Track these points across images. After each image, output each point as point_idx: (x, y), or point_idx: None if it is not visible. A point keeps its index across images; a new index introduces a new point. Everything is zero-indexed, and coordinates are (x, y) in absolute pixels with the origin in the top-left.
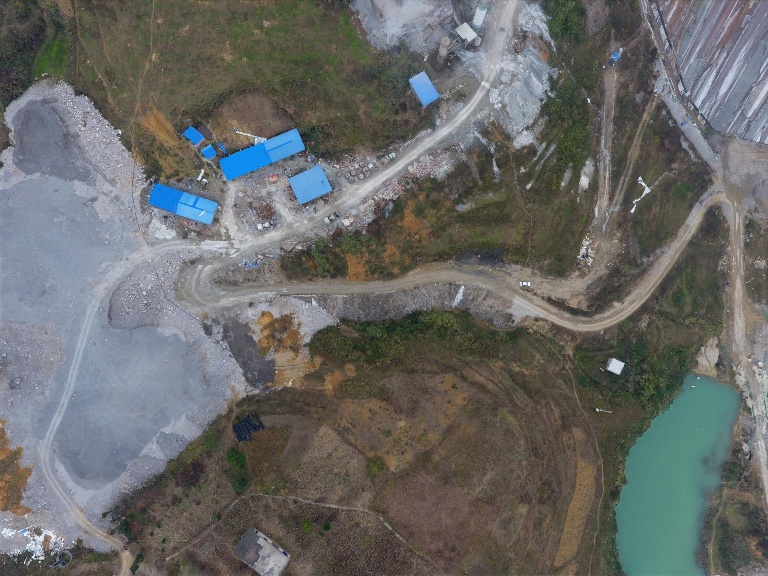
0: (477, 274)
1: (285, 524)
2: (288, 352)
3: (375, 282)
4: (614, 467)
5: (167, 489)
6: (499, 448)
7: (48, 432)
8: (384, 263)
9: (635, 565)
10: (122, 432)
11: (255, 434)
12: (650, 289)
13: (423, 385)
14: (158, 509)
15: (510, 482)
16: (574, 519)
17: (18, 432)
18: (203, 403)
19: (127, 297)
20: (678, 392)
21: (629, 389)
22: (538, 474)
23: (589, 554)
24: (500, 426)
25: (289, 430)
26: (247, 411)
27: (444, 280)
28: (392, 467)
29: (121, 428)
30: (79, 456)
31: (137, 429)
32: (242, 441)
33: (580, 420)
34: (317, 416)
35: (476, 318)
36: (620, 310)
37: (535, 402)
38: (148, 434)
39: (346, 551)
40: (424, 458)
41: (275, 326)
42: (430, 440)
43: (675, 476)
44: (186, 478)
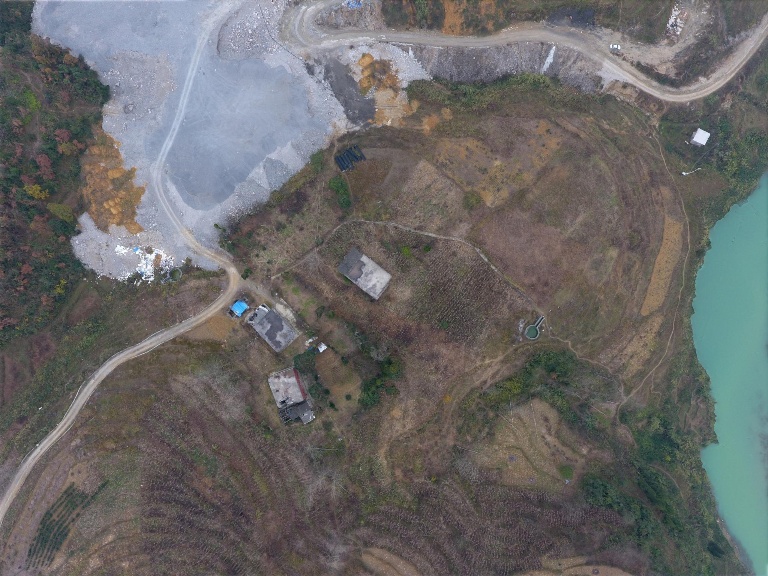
0: (568, 35)
1: (387, 246)
2: (388, 90)
3: (469, 37)
4: (700, 227)
5: (271, 216)
6: (591, 192)
7: (160, 154)
8: (480, 15)
9: (707, 357)
10: (230, 156)
11: (357, 164)
12: (735, 69)
13: (518, 128)
14: (263, 234)
15: (602, 224)
16: (661, 271)
17: (132, 153)
18: (308, 132)
19: (233, 35)
20: (756, 183)
21: (713, 162)
22: (628, 222)
23: (674, 309)
24: (593, 171)
25: (390, 161)
26: (348, 145)
27: (536, 39)
28: (488, 202)
29: (229, 153)
30: (189, 177)
31: (245, 154)
32: (344, 170)
33: (668, 178)
34: (416, 151)
35: (564, 85)
36: (706, 85)
37: (625, 156)
38: (256, 157)
39: (443, 279)
40: (519, 195)
41: (375, 67)
42: (525, 180)
43: (749, 272)
44: (290, 204)
